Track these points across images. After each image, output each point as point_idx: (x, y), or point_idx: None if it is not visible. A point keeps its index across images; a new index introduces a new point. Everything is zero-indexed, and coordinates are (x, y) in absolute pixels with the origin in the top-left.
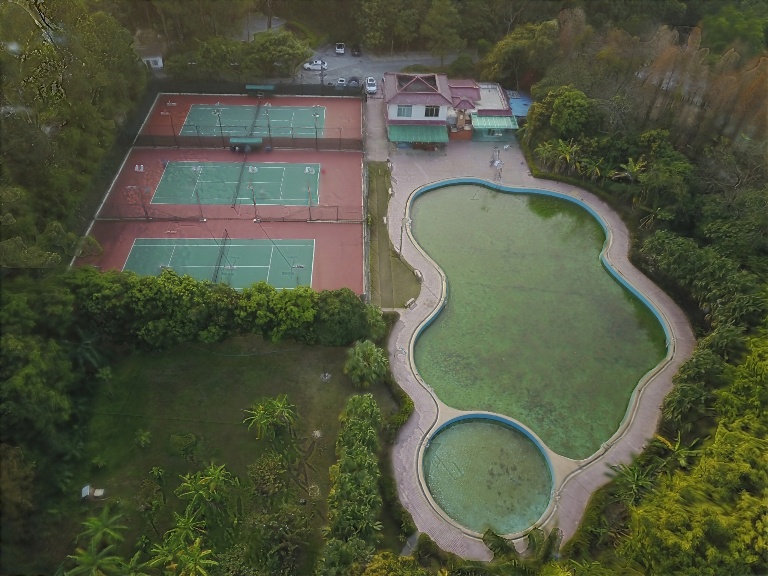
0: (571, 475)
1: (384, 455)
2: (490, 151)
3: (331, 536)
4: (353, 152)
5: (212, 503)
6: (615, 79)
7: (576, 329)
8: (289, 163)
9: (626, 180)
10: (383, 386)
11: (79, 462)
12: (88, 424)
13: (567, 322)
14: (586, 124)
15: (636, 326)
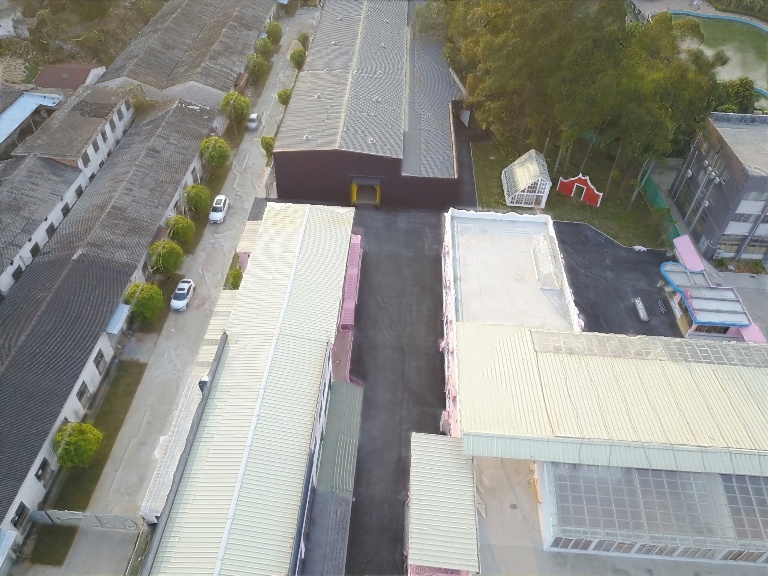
0: None
1: None
2: (686, 0)
3: None
4: None
5: None
6: None
7: (766, 64)
8: None
9: None
10: None
11: None
12: None
13: (760, 61)
14: None
15: None
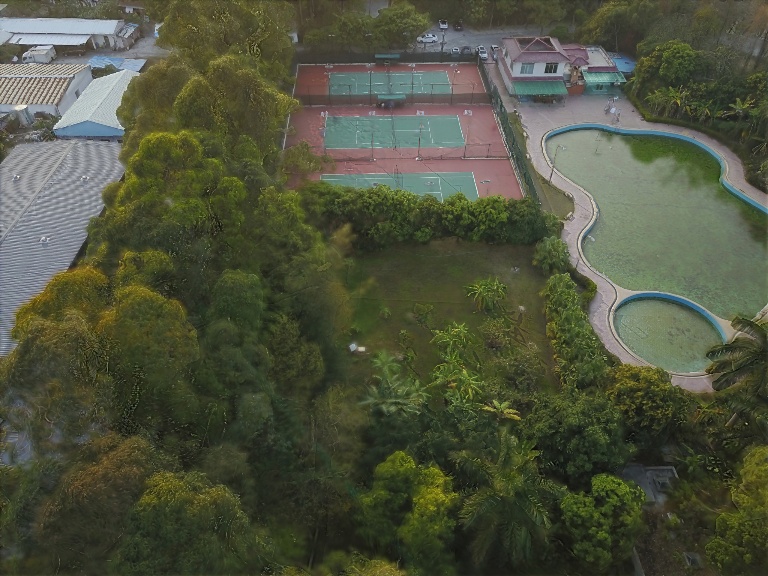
0: (738, 333)
1: None
2: (602, 102)
3: (568, 366)
4: (483, 106)
5: (463, 349)
6: (713, 35)
7: (713, 234)
8: (431, 115)
9: (734, 118)
10: None
11: None
12: None
13: (704, 229)
14: (693, 73)
15: (764, 231)
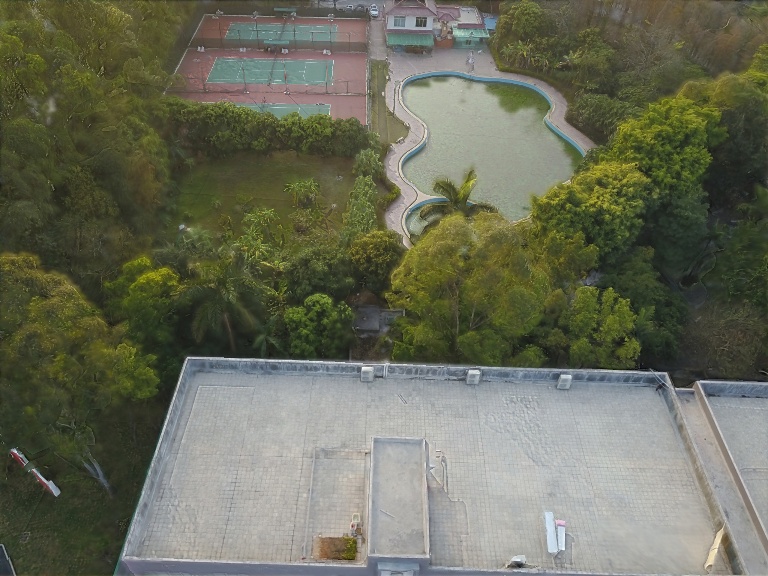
0: None
1: (379, 213)
2: (467, 55)
3: None
4: (359, 54)
5: (267, 227)
6: None
7: (520, 158)
8: (310, 59)
9: (568, 68)
10: (379, 182)
11: (175, 214)
12: (178, 197)
13: (514, 155)
14: (540, 29)
15: (564, 157)
